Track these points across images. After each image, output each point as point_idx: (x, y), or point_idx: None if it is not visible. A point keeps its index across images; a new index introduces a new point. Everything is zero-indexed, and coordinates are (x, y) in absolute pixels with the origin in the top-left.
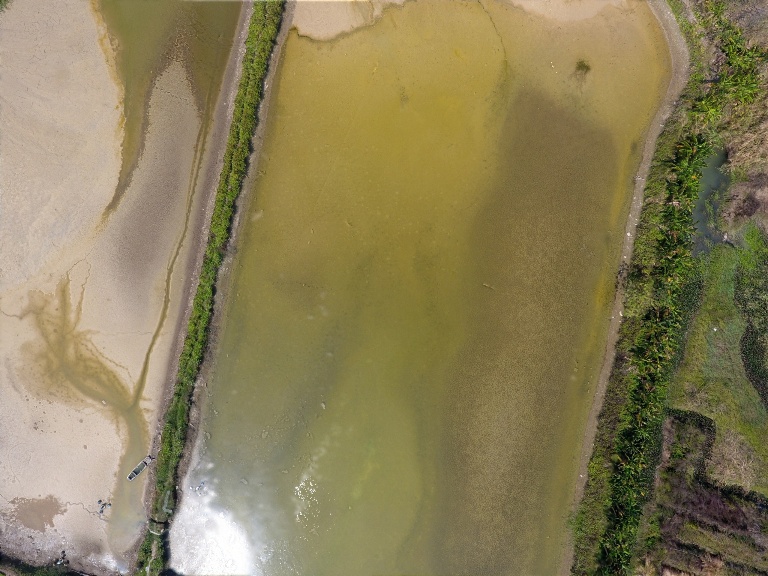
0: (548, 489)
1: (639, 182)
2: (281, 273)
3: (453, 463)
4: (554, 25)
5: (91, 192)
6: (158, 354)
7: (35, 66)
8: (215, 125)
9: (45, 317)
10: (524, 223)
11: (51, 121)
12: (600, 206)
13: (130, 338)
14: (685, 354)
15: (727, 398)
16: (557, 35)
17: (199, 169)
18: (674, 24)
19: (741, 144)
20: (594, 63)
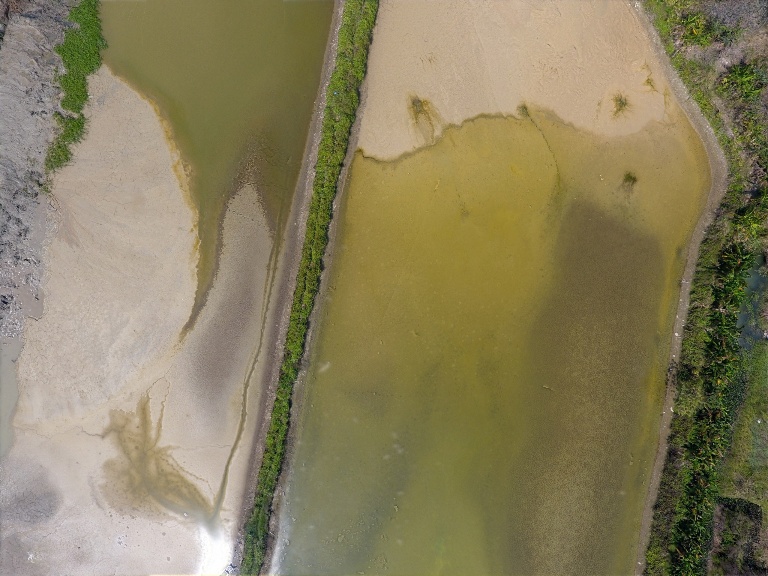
0: None
1: (685, 285)
2: (353, 383)
3: (520, 557)
4: (602, 140)
5: (168, 313)
6: (237, 466)
7: (112, 193)
8: (286, 244)
9: (126, 435)
10: (580, 327)
11: (128, 246)
12: (649, 308)
13: (209, 452)
14: (732, 445)
15: None
16: (605, 150)
17: (272, 287)
18: (712, 137)
19: None
20: (640, 175)
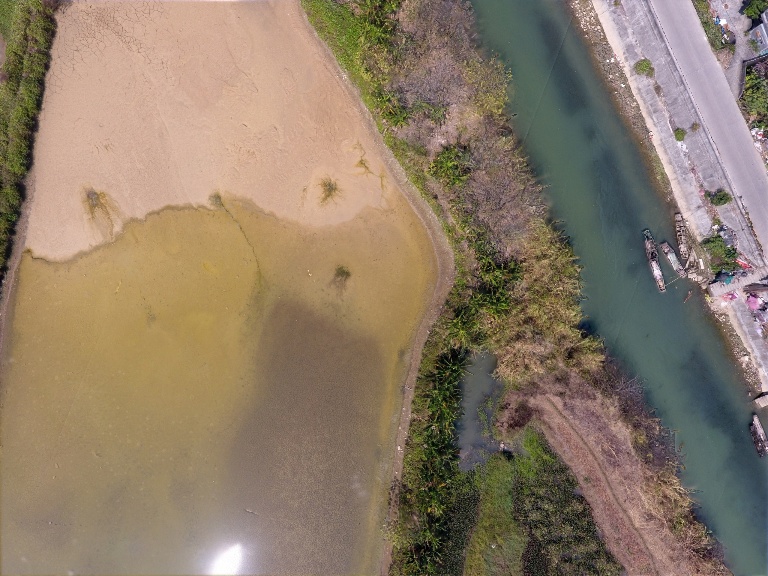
0: None
1: (408, 392)
2: (25, 512)
3: None
4: (309, 231)
5: None
6: None
7: None
8: None
9: None
10: (287, 442)
11: None
12: (368, 419)
13: None
14: (463, 574)
15: None
16: (313, 241)
17: None
18: (436, 224)
19: (504, 356)
20: (354, 268)
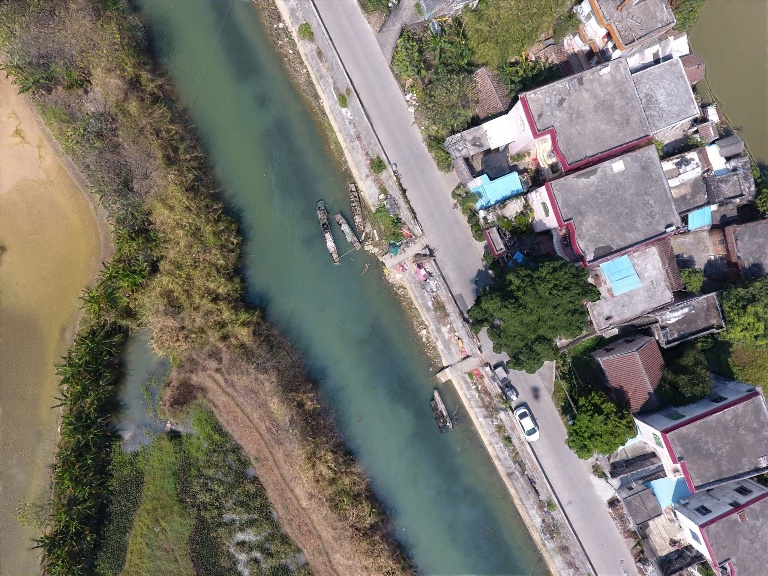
0: None
1: None
2: None
3: None
4: None
5: None
6: None
7: None
8: None
9: None
10: None
11: None
12: (27, 400)
13: None
14: (126, 559)
15: None
16: None
17: None
18: (97, 196)
19: None
20: (10, 243)
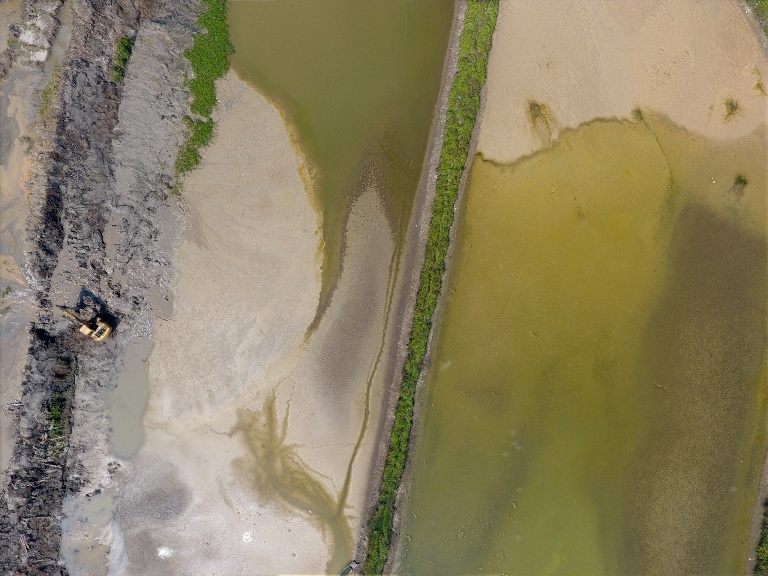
0: (720, 573)
1: None
2: (472, 382)
3: (634, 553)
4: (714, 144)
5: (294, 313)
6: (360, 464)
7: (239, 196)
8: (408, 246)
9: (253, 433)
10: (692, 327)
11: (255, 247)
12: (759, 309)
13: (333, 450)
14: None
15: None
16: (717, 153)
17: (394, 288)
18: None
19: None
20: (750, 178)
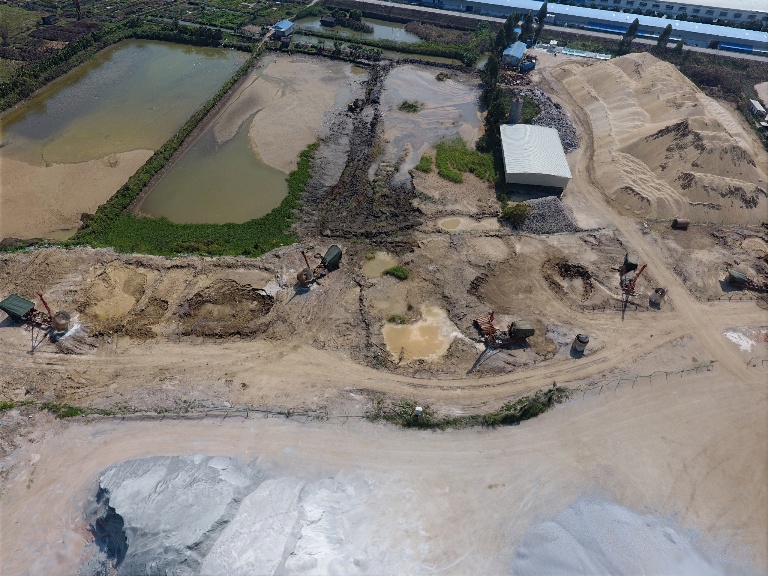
0: None
1: None
2: None
3: None
4: (7, 157)
5: None
6: (247, 84)
7: None
8: (207, 128)
9: (292, 90)
10: None
11: None
12: None
13: None
14: None
15: (4, 74)
16: (8, 154)
17: None
18: None
19: None
20: None
